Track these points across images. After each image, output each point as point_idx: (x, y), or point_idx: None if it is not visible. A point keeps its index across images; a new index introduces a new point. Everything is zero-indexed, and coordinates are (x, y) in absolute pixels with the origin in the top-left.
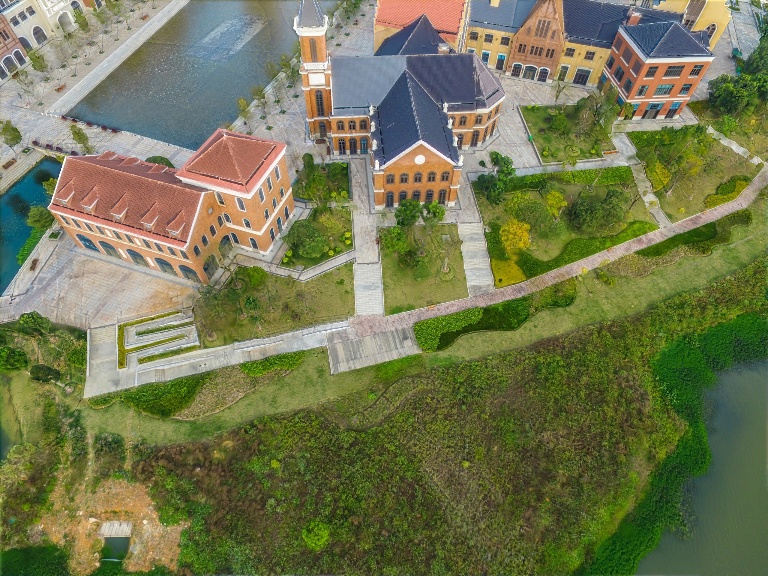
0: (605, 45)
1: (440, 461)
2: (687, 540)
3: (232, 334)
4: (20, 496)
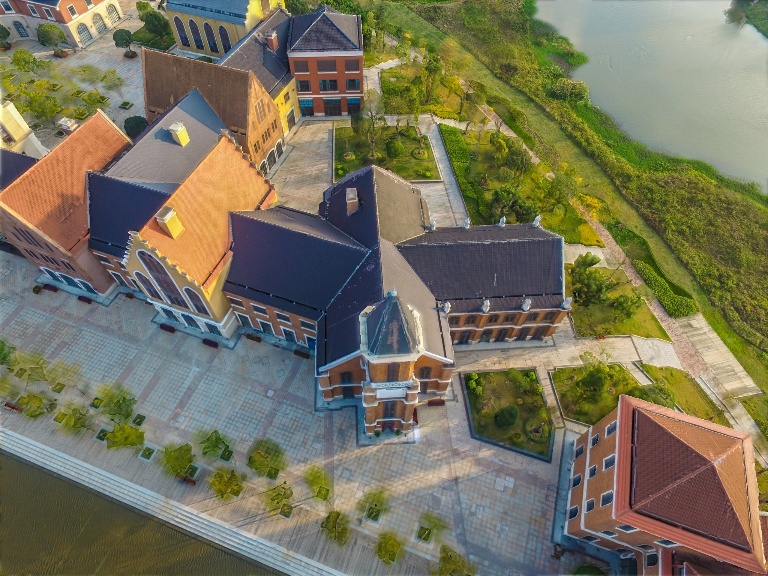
0: (288, 78)
1: None
2: (762, 184)
3: None
4: None
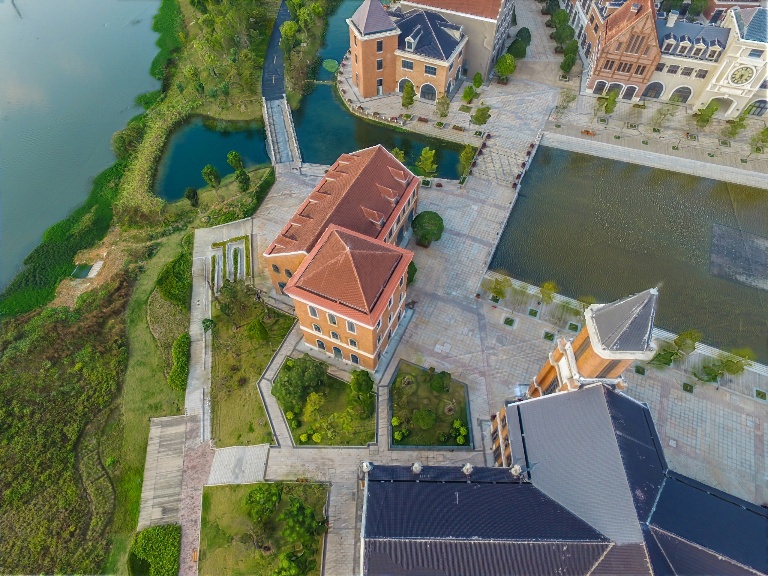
0: None
1: (4, 531)
2: None
3: (222, 322)
4: (135, 213)
